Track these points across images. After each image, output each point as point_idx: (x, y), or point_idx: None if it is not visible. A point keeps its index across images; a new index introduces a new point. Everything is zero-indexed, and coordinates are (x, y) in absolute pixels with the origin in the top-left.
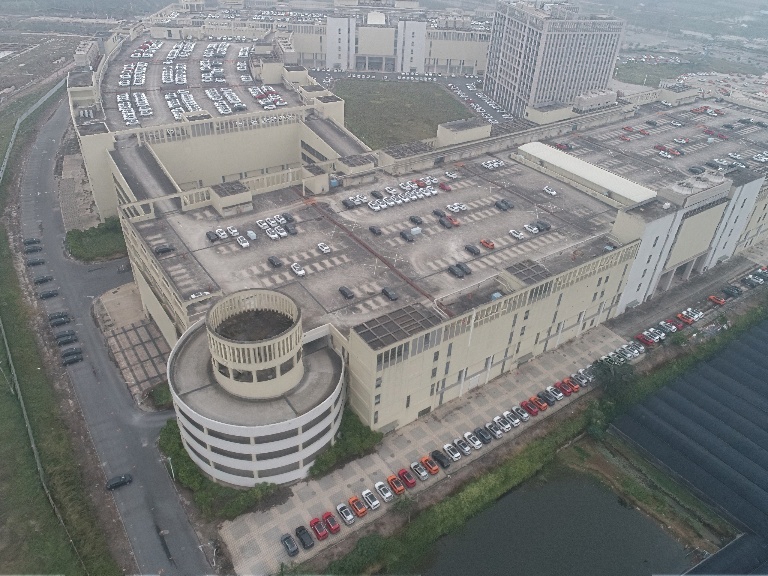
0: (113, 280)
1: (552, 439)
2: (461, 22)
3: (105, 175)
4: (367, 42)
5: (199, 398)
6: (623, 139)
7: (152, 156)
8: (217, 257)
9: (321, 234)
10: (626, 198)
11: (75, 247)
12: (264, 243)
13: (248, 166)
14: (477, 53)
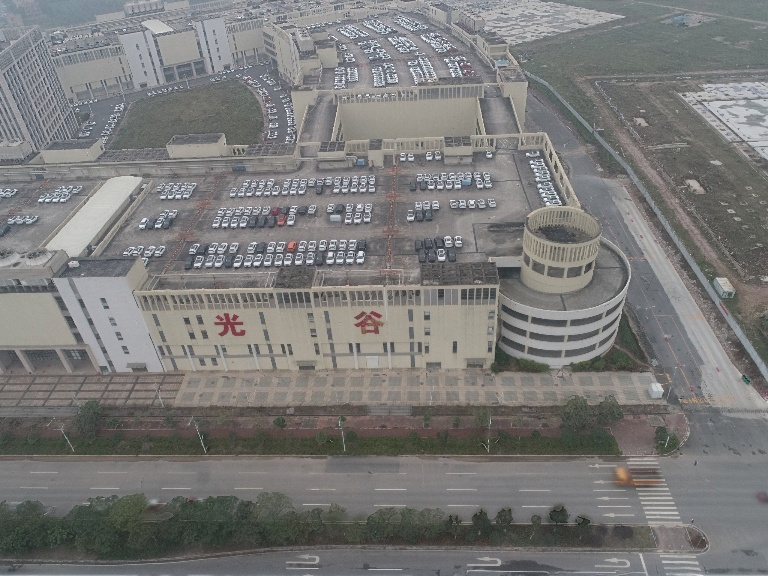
0: None
1: None
2: None
3: None
4: None
5: None
6: None
7: None
8: None
9: None
10: None
11: None
12: None
13: None
14: None
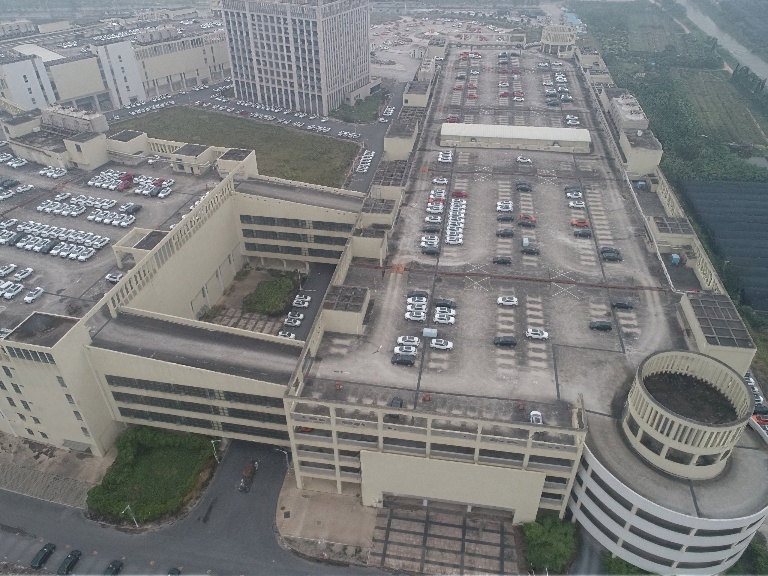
0: (255, 505)
1: (759, 344)
2: (165, 31)
3: (89, 386)
4: (66, 83)
5: (710, 506)
6: (472, 98)
7: (154, 319)
8: (450, 376)
9: (472, 292)
10: (575, 142)
11: (138, 509)
12: (453, 333)
13: (206, 275)
14: (194, 61)
